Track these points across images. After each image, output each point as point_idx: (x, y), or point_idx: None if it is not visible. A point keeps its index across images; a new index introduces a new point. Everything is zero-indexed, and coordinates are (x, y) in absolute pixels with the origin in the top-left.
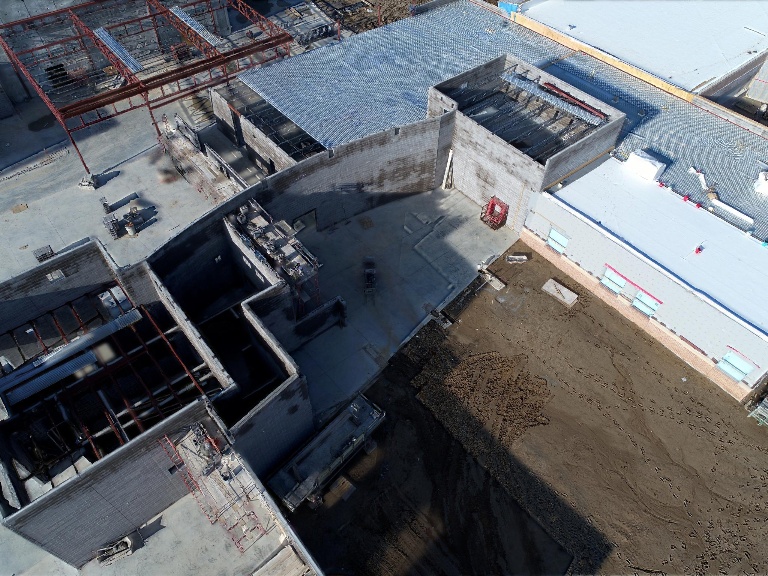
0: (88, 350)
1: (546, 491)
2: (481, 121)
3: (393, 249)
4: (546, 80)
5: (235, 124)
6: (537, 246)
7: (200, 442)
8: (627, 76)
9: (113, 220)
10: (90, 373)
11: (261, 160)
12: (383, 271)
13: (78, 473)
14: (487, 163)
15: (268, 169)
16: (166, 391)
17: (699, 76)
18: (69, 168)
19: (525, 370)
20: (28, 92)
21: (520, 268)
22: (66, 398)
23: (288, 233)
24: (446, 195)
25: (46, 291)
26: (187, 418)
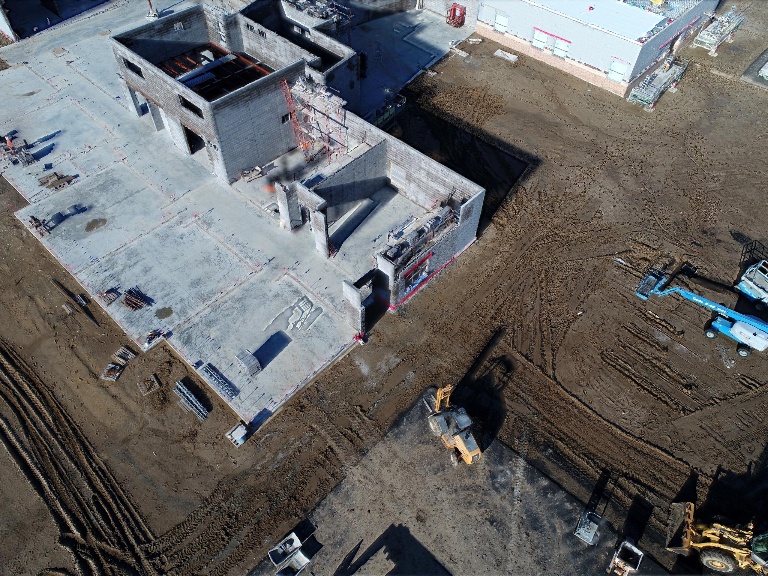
0: (207, 72)
1: (509, 140)
2: None
3: (389, 41)
4: None
5: None
6: (488, 33)
7: (305, 85)
8: None
9: None
10: (214, 82)
11: None
12: (385, 51)
13: None
14: None
15: None
16: None
17: None
18: (133, 10)
19: (488, 92)
20: None
21: (478, 46)
22: (204, 92)
23: (326, 4)
24: (420, 12)
25: (172, 39)
26: (296, 71)
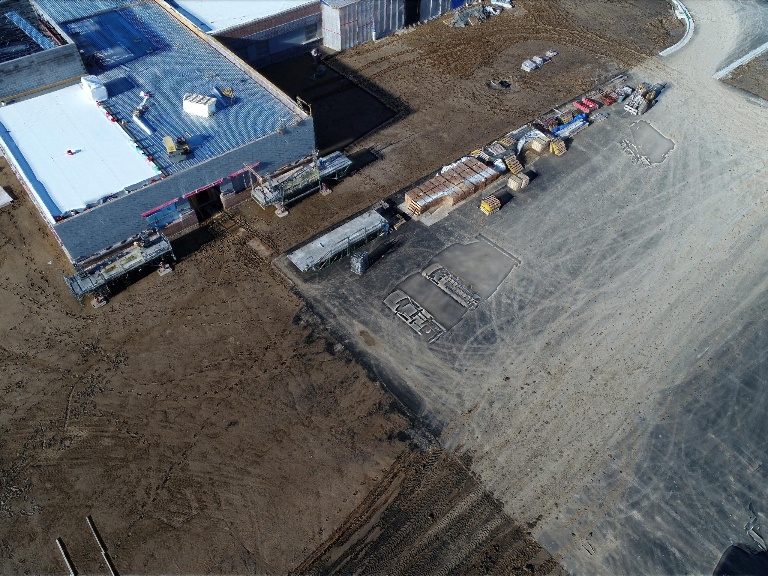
0: None
1: None
2: None
3: None
4: (45, 17)
5: None
6: None
7: None
8: (174, 21)
9: None
10: None
11: None
12: None
13: None
14: None
15: None
16: None
17: (240, 21)
18: None
19: None
20: None
21: None
22: None
23: None
24: None
25: None
26: None
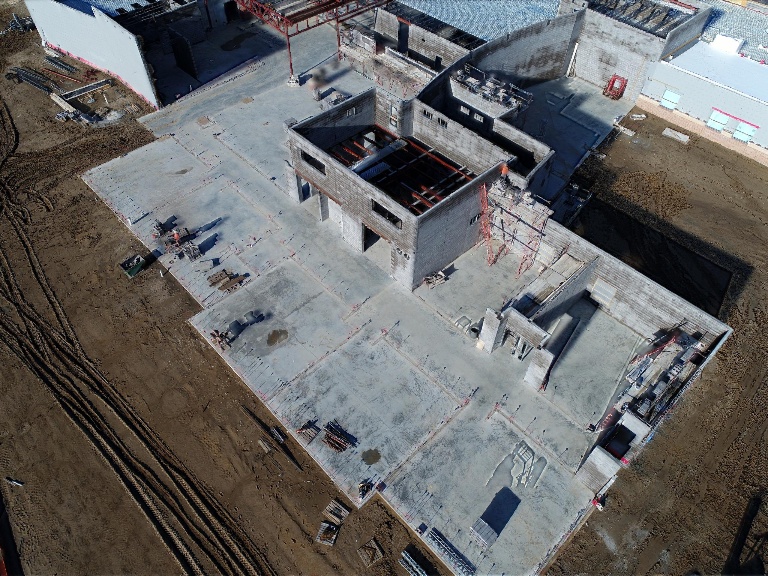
0: (380, 162)
1: (704, 242)
2: (608, 14)
3: (545, 115)
4: None
5: (399, 35)
6: (651, 108)
7: (504, 189)
8: None
9: (332, 101)
10: (389, 174)
11: (425, 60)
12: None
13: (448, 196)
14: (611, 47)
15: (431, 67)
16: (446, 182)
17: None
18: (271, 74)
19: (666, 180)
20: (211, 23)
21: (642, 123)
22: (382, 186)
23: (499, 85)
24: (571, 81)
25: (343, 124)
26: (494, 174)
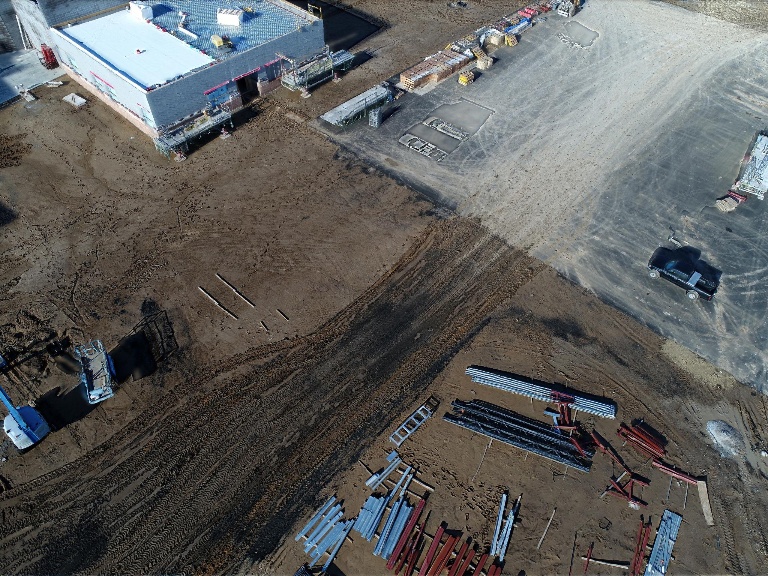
0: None
1: None
2: None
3: None
4: None
5: None
6: (72, 75)
7: None
8: None
9: None
10: None
11: None
12: None
13: None
14: (29, 17)
15: None
16: None
17: None
18: None
19: (21, 141)
20: None
21: (55, 90)
22: None
23: None
24: (26, 53)
25: None
26: None
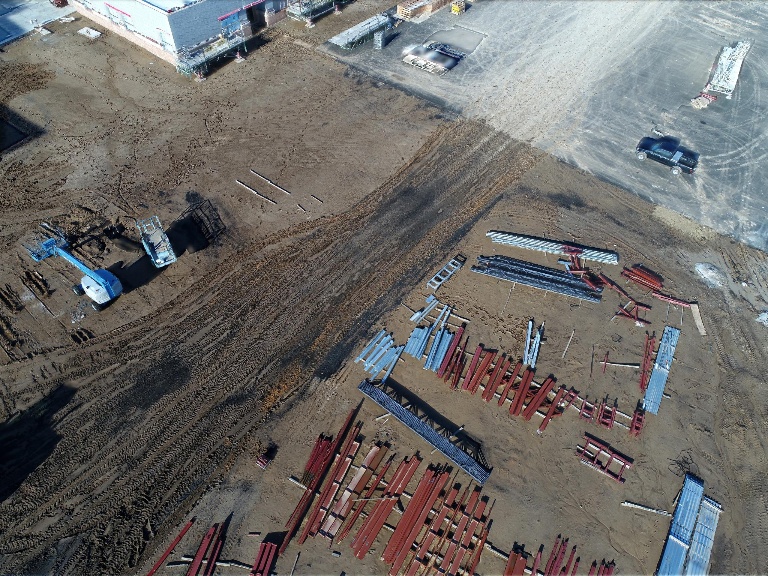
0: None
1: (26, 114)
2: None
3: None
4: None
5: None
6: (83, 11)
7: None
8: None
9: None
10: None
11: None
12: None
13: None
14: None
15: None
16: None
17: None
18: None
19: (43, 68)
20: None
21: (68, 25)
22: None
23: None
24: None
25: None
26: None
